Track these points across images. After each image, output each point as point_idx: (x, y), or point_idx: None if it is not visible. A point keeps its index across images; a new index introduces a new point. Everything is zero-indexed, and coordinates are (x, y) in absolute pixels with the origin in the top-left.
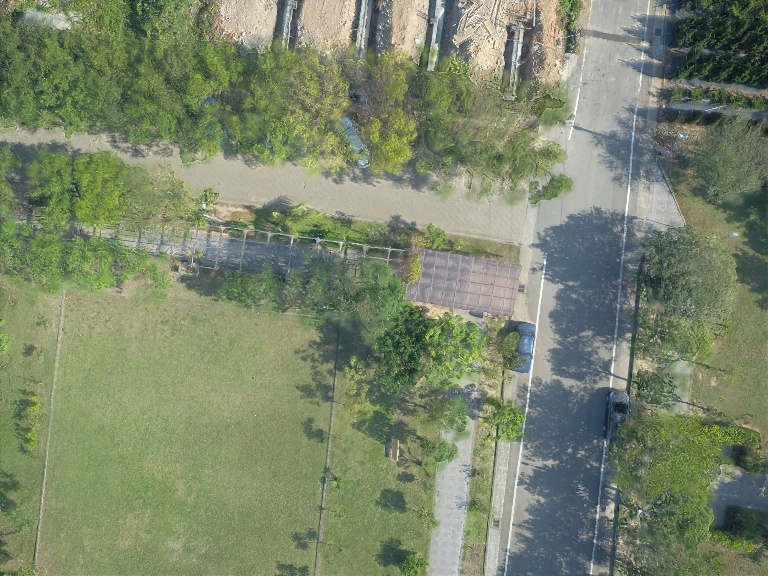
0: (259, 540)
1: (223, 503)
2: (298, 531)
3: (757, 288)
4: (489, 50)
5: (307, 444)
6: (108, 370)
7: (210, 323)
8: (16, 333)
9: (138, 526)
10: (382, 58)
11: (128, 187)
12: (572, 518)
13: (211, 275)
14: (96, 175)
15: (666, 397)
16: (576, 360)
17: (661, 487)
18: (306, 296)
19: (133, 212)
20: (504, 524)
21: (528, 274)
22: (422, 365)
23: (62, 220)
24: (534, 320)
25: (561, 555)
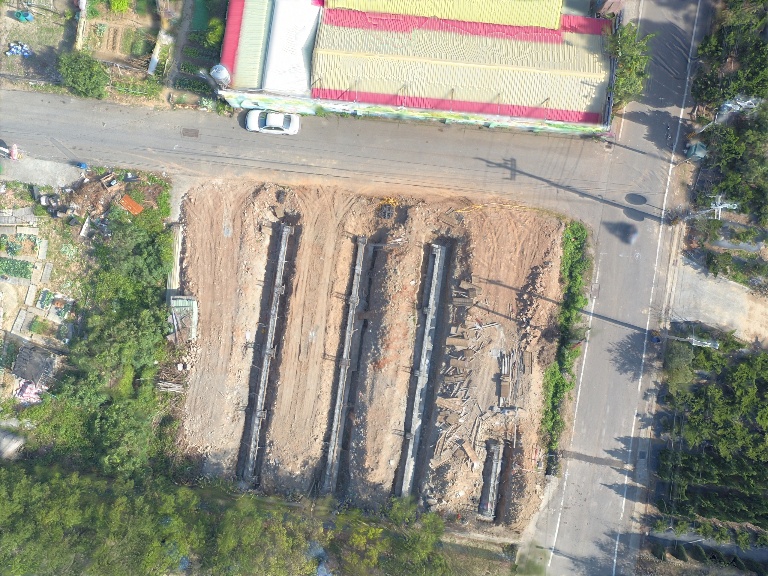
0: None
1: None
2: None
3: None
4: (467, 474)
5: None
6: None
7: None
8: None
9: None
10: (355, 478)
11: None
12: None
13: None
14: None
15: None
16: None
17: None
18: None
19: None
20: None
21: None
22: None
23: None
24: None
25: None
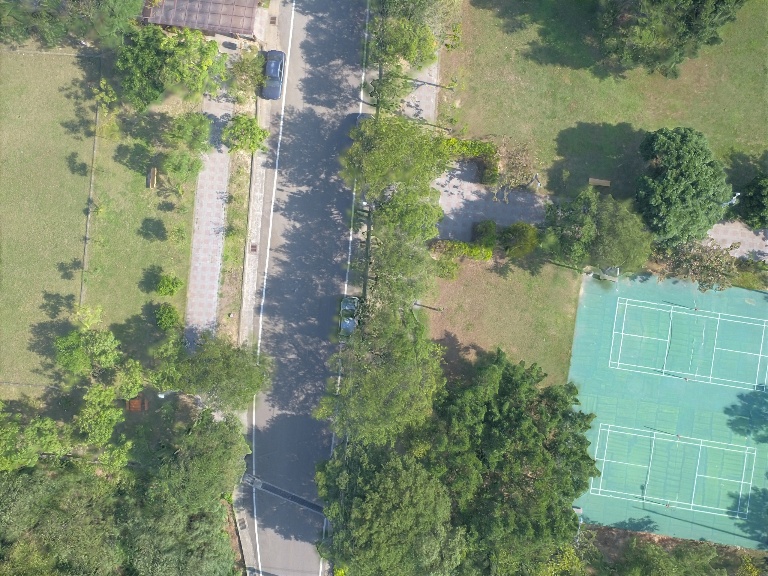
0: (27, 271)
1: None
2: (64, 261)
3: (498, 13)
4: None
5: (71, 178)
6: None
7: None
8: None
9: None
10: None
11: None
12: (326, 241)
13: None
14: None
15: (413, 120)
16: (327, 88)
17: (376, 171)
18: (66, 34)
19: None
20: (261, 249)
21: (279, 7)
22: (158, 73)
23: None
24: (285, 51)
25: (317, 277)
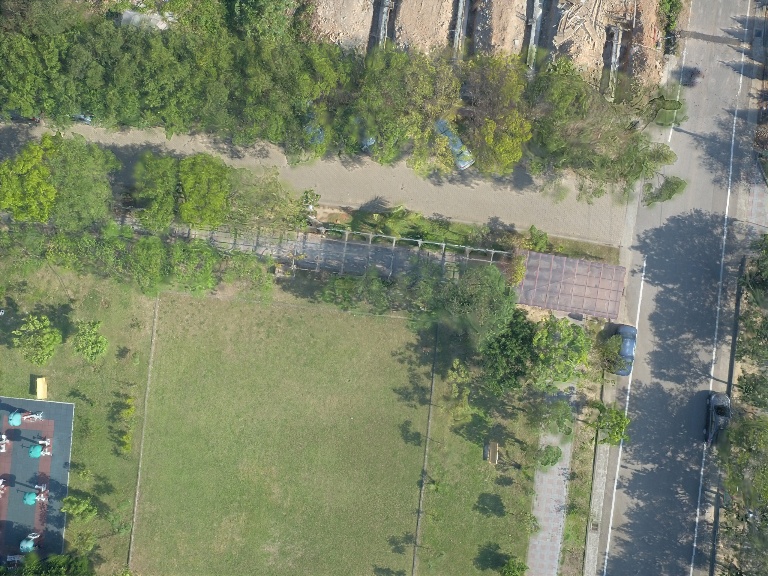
0: (356, 544)
1: (319, 506)
2: (395, 535)
3: None
4: (589, 51)
5: (404, 447)
6: (203, 372)
7: (306, 325)
8: (109, 335)
9: (233, 529)
10: (481, 59)
11: (235, 188)
12: (671, 522)
13: (307, 277)
14: (203, 176)
15: None
16: (676, 363)
17: None
18: (404, 298)
19: (240, 213)
20: (603, 528)
21: (628, 276)
22: (530, 368)
23: (167, 221)
24: (634, 323)
25: (660, 559)
